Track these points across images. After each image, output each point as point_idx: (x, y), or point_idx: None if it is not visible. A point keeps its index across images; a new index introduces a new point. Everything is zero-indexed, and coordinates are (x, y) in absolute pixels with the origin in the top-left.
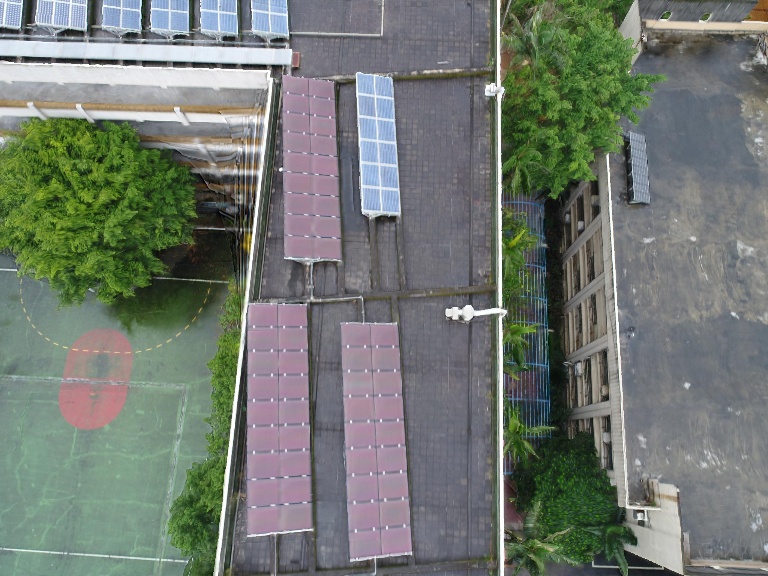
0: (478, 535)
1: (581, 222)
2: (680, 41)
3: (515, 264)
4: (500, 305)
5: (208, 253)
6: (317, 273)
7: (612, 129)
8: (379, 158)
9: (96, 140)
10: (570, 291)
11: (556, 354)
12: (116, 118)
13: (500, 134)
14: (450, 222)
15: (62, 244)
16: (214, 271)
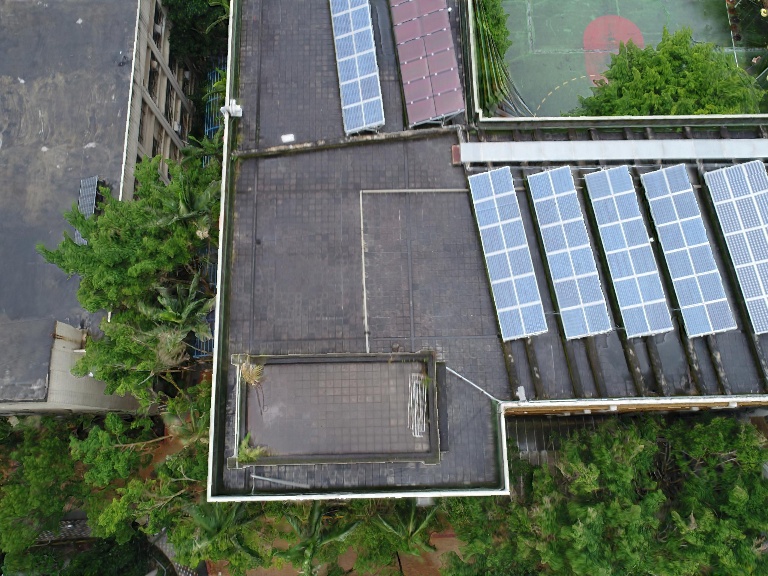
0: None
1: None
2: (5, 388)
3: None
4: None
5: None
6: None
7: None
8: (353, 39)
9: None
10: None
11: None
12: None
13: (228, 65)
14: None
15: None
16: None
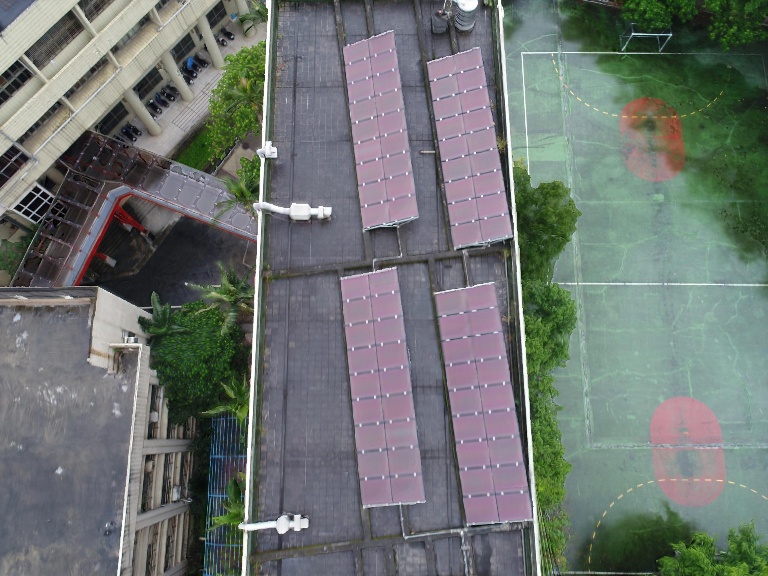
0: (280, 298)
1: None
2: None
3: None
4: (246, 535)
5: None
6: (460, 567)
7: None
8: None
9: None
10: None
11: (199, 510)
12: None
13: None
14: None
15: None
16: None
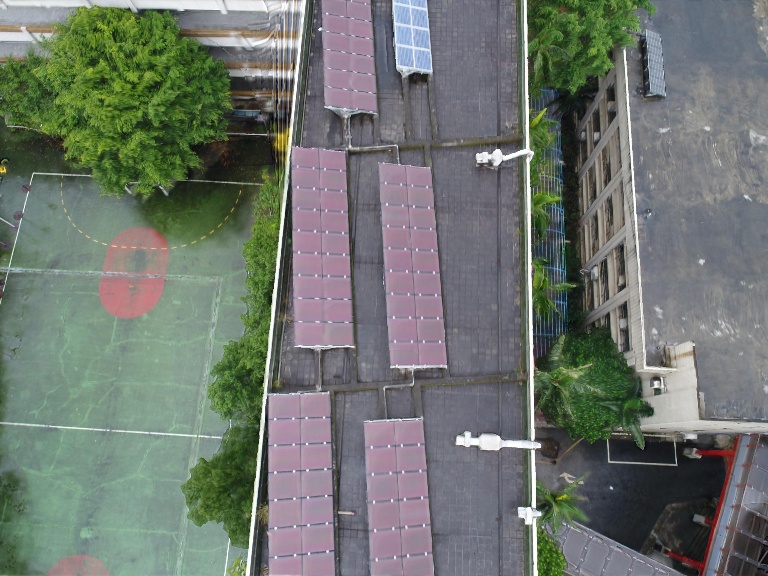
0: (508, 353)
1: (597, 133)
2: None
3: (537, 145)
4: (527, 148)
5: (239, 158)
6: (354, 126)
7: (629, 19)
8: (412, 21)
9: (140, 26)
10: (586, 205)
11: (573, 261)
12: (158, 7)
13: None
14: (479, 81)
15: (108, 123)
16: (245, 174)
